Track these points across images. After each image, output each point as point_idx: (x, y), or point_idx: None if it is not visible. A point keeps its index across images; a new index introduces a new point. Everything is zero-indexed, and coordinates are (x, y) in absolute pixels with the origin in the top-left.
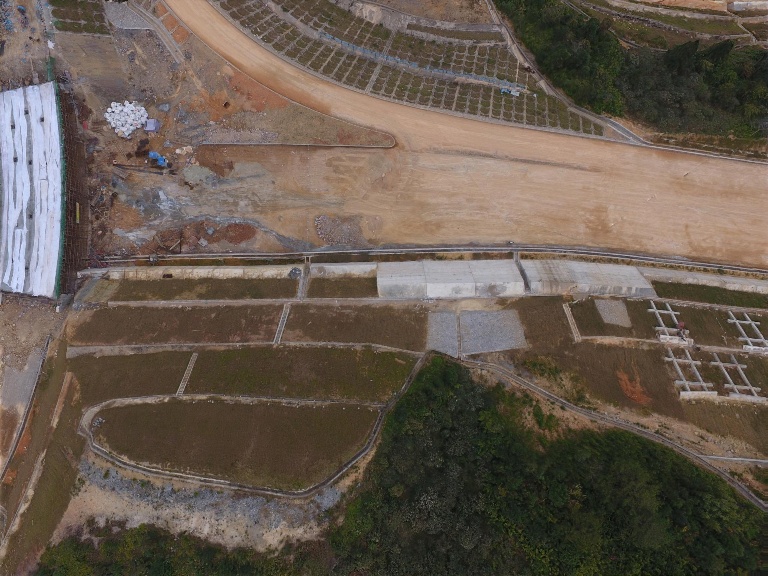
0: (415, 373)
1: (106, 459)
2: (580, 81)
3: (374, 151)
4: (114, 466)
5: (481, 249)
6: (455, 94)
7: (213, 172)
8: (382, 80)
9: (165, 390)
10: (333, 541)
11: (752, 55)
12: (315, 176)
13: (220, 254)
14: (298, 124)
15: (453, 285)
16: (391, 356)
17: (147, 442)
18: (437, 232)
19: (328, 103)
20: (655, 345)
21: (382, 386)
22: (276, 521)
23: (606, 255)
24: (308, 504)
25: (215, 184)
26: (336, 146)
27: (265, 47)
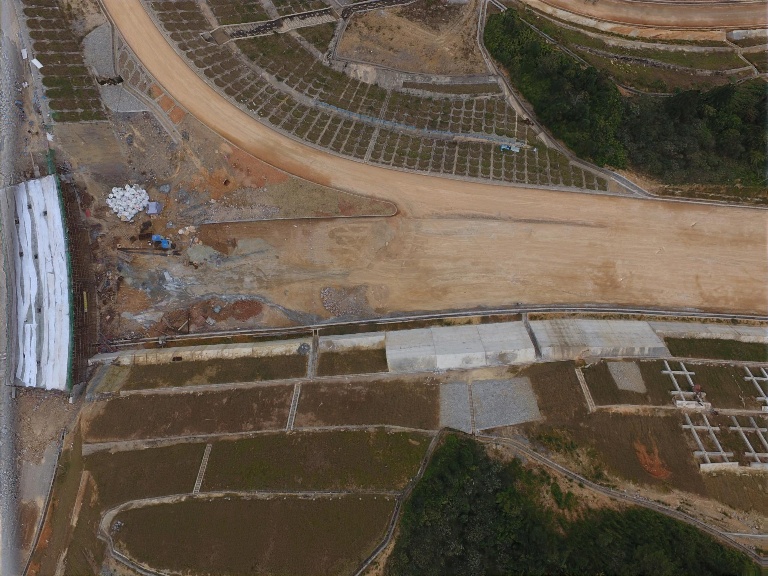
0: (430, 454)
1: (127, 566)
2: (580, 134)
3: (376, 220)
4: (135, 573)
5: (489, 312)
6: (455, 155)
7: (217, 251)
8: (380, 146)
9: (181, 489)
10: None
11: (755, 91)
12: (318, 248)
13: (228, 332)
14: (299, 198)
15: (463, 355)
16: (405, 437)
17: (166, 547)
18: (444, 297)
19: (328, 174)
20: (672, 411)
21: (397, 472)
22: None
23: (616, 311)
24: None
25: (219, 262)
26: (338, 217)
27: (262, 122)
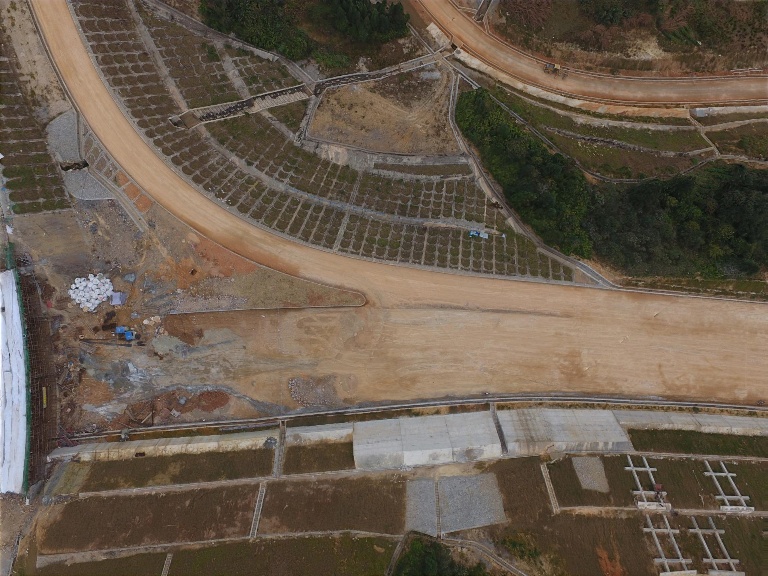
0: (394, 561)
1: None
2: (547, 223)
3: (345, 310)
4: None
5: (457, 402)
6: (424, 242)
7: (182, 342)
8: (350, 233)
9: None
10: None
11: (716, 174)
12: (286, 338)
13: (193, 424)
14: (267, 288)
15: (430, 452)
16: (370, 543)
17: None
18: (412, 387)
19: (296, 264)
20: (633, 513)
21: None
22: None
23: (582, 400)
24: None
25: (185, 353)
26: (306, 307)
27: (230, 211)
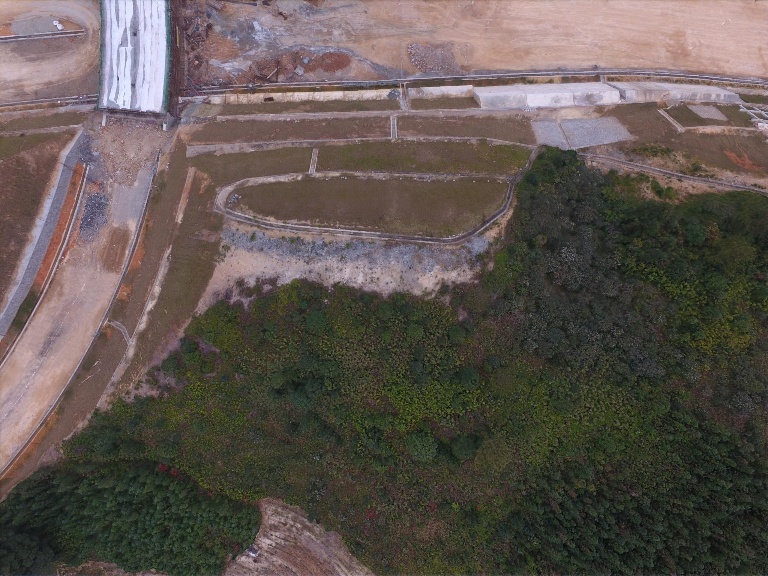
0: (532, 160)
1: (250, 224)
2: None
3: None
4: (260, 229)
5: (569, 73)
6: None
7: (307, 1)
8: None
9: (297, 169)
10: (488, 281)
11: None
12: (406, 5)
13: (317, 82)
14: None
15: (552, 95)
16: (506, 147)
17: (291, 206)
18: (526, 58)
19: None
20: (754, 132)
21: (507, 164)
22: (430, 265)
23: (687, 77)
24: (459, 249)
25: (308, 14)
26: None
27: None
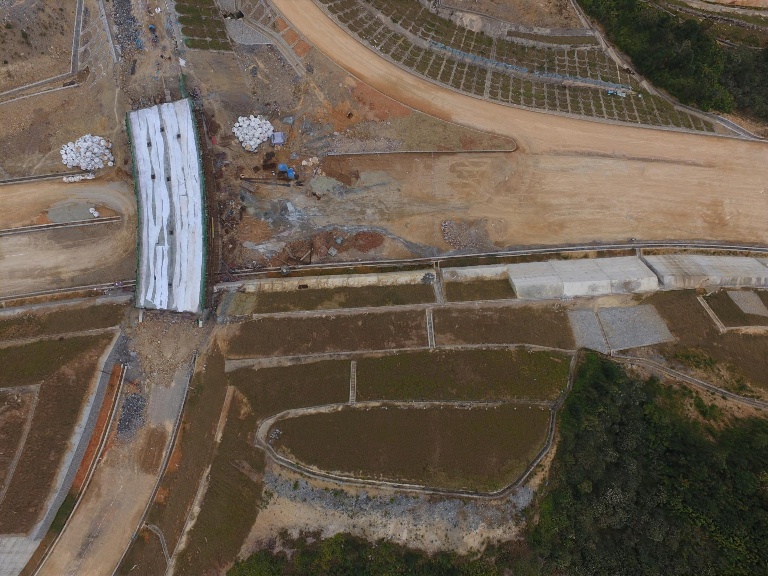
0: (572, 371)
1: (293, 470)
2: (686, 80)
3: (496, 155)
4: (303, 477)
5: (604, 247)
6: (566, 97)
7: (340, 182)
8: (496, 86)
9: (337, 399)
10: (534, 540)
11: None
12: (439, 182)
13: (350, 263)
14: (421, 132)
15: (589, 283)
16: (546, 355)
17: (333, 451)
18: (560, 232)
19: (449, 110)
20: None
21: (548, 385)
22: (475, 523)
23: (725, 248)
24: (505, 504)
25: (342, 194)
26: (459, 152)
27: (385, 58)
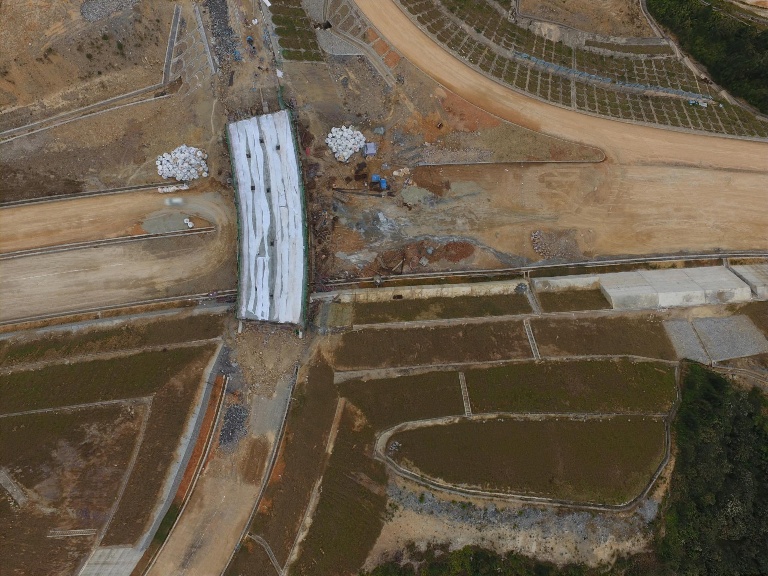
0: (678, 382)
1: (418, 483)
2: (767, 90)
3: (584, 166)
4: (428, 489)
5: (691, 257)
6: (650, 107)
7: (431, 192)
8: (582, 96)
9: (453, 411)
10: (663, 552)
11: None
12: (529, 192)
13: (441, 273)
14: (511, 142)
15: (683, 293)
16: (650, 366)
17: (457, 464)
18: (648, 242)
19: (537, 121)
20: None
21: (658, 396)
22: (604, 536)
23: None
24: (632, 517)
25: (432, 204)
26: (548, 162)
27: (474, 68)
